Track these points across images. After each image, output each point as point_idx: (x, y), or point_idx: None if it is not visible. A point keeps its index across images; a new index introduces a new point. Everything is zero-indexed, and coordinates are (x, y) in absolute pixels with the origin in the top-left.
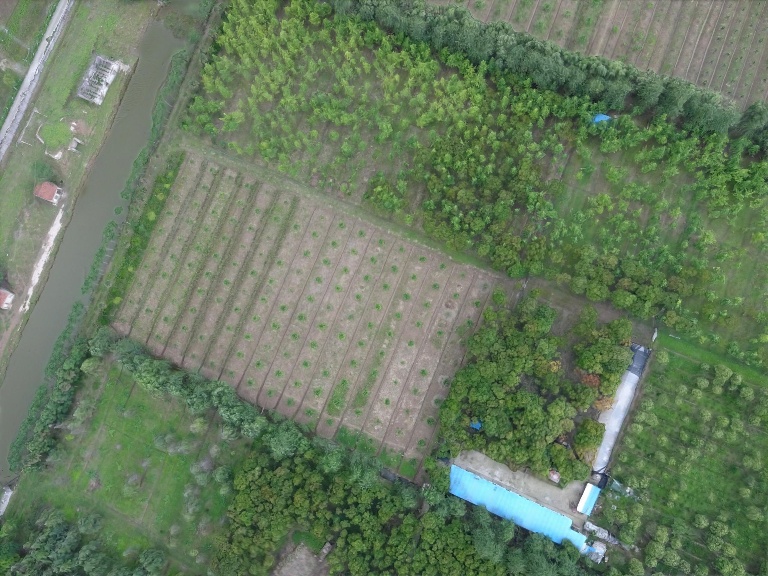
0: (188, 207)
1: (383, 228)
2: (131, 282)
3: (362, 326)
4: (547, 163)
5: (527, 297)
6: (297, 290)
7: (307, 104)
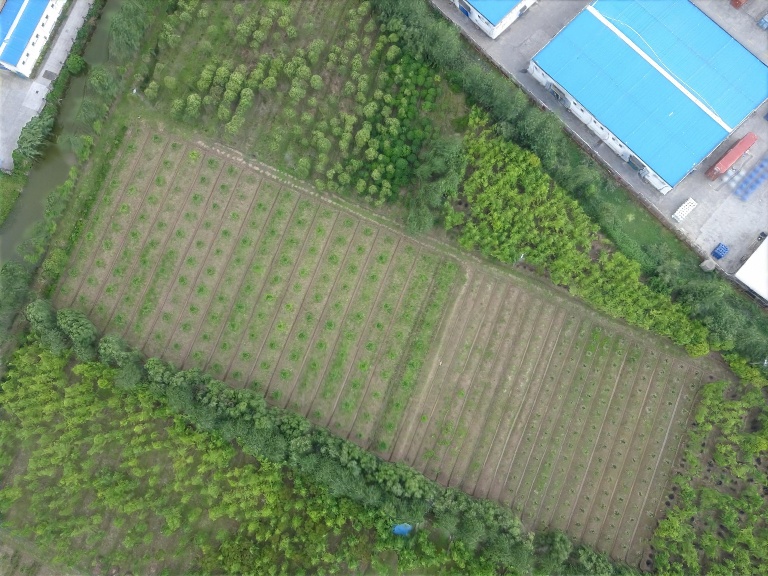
0: None
1: None
2: None
3: None
4: (345, 568)
5: None
6: None
7: (90, 484)
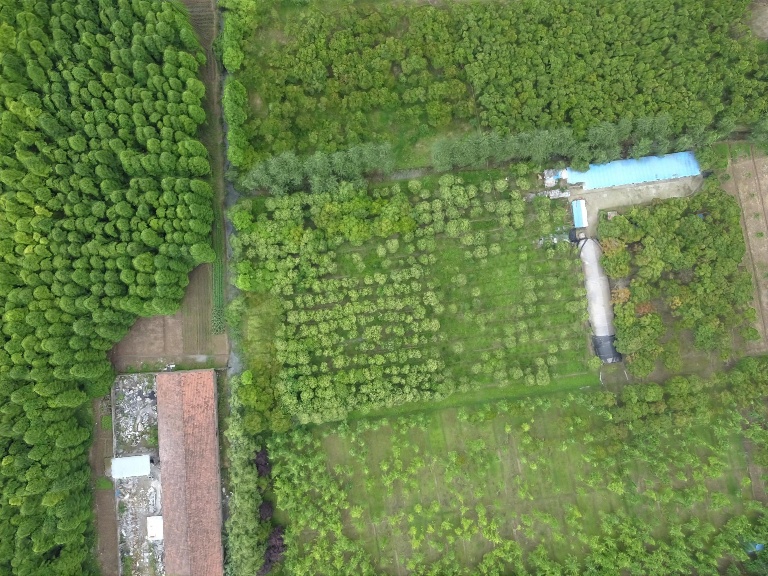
0: None
1: None
2: None
3: None
4: None
5: None
6: None
7: None
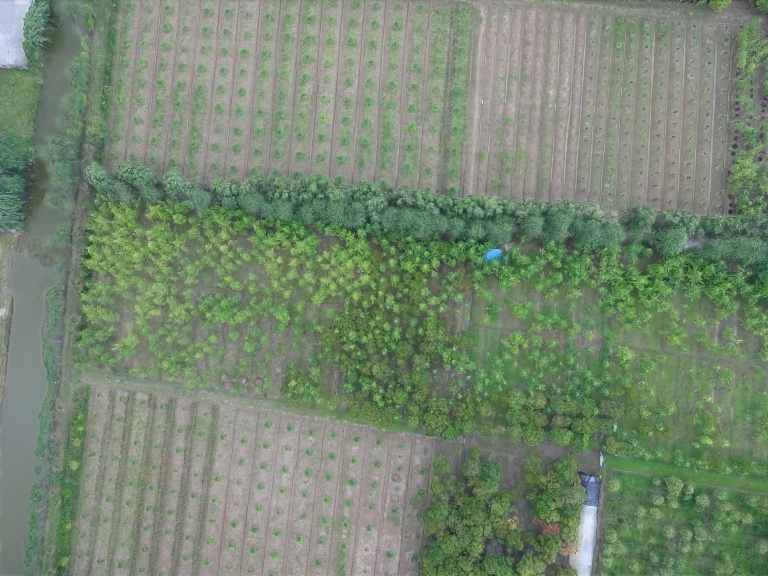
0: (109, 443)
1: (309, 416)
2: (74, 535)
3: (316, 522)
4: (452, 310)
5: (468, 460)
6: (242, 501)
7: (197, 310)
